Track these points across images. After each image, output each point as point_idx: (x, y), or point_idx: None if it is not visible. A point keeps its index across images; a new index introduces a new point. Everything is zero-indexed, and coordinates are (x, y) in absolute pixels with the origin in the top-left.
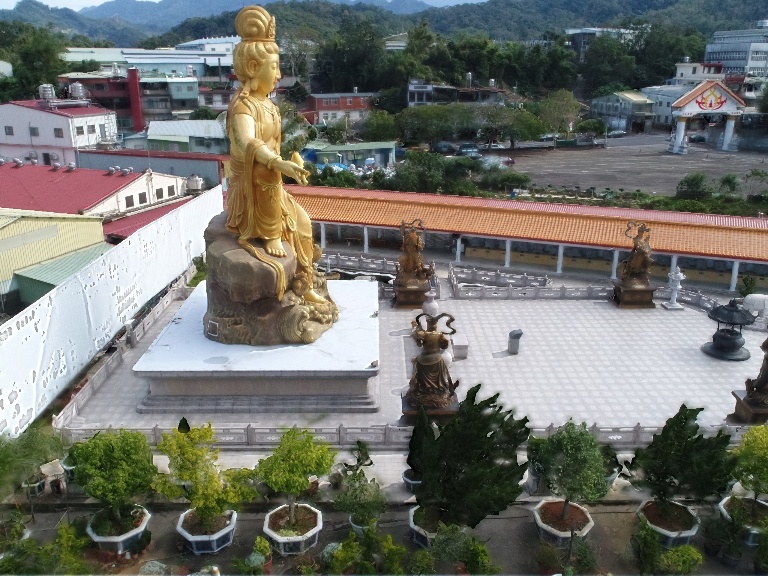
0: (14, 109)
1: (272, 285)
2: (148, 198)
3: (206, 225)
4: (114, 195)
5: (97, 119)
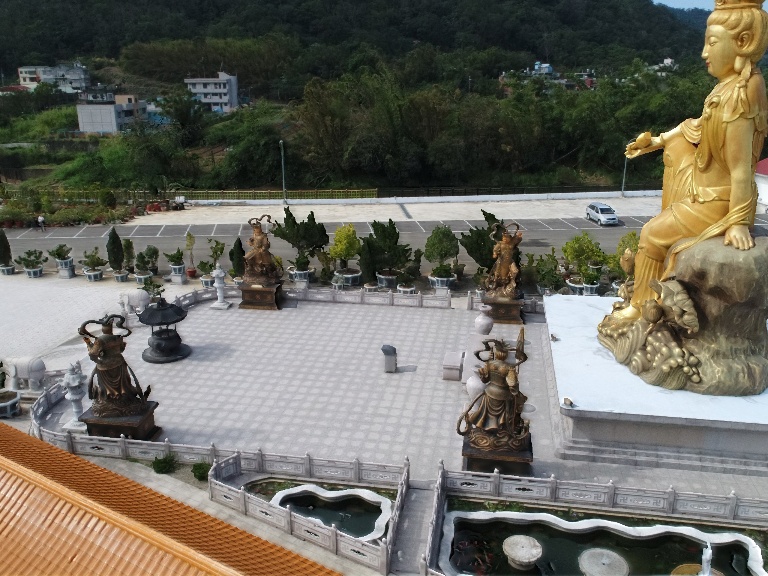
0: None
1: None
2: None
3: None
4: None
5: None
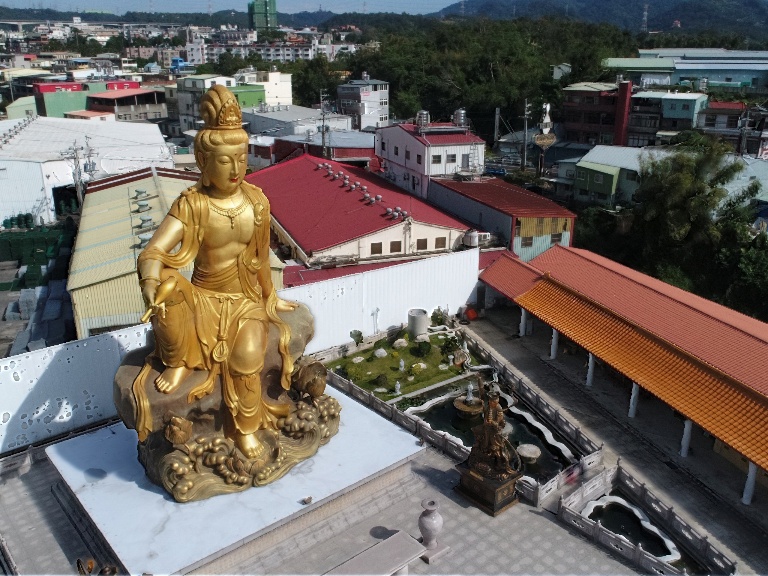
0: (401, 132)
1: (134, 421)
2: (404, 247)
3: (429, 292)
4: (356, 240)
5: (461, 148)
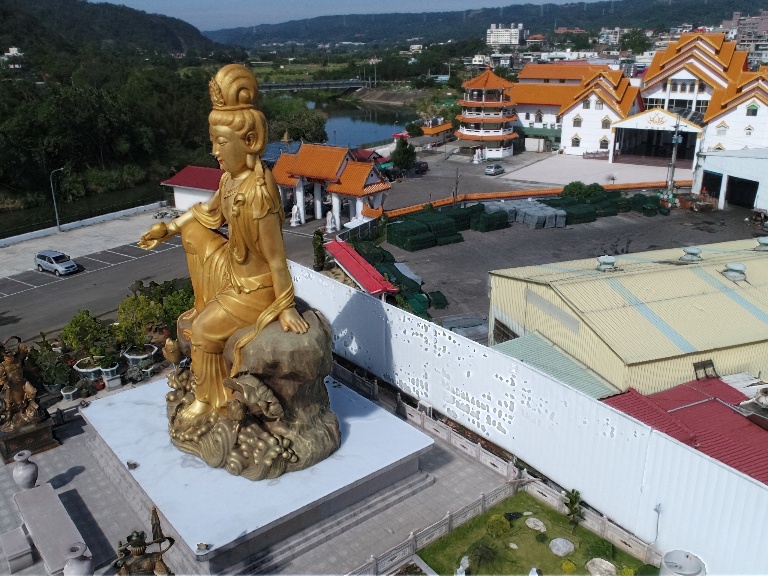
0: None
1: None
2: None
3: None
4: None
5: None
